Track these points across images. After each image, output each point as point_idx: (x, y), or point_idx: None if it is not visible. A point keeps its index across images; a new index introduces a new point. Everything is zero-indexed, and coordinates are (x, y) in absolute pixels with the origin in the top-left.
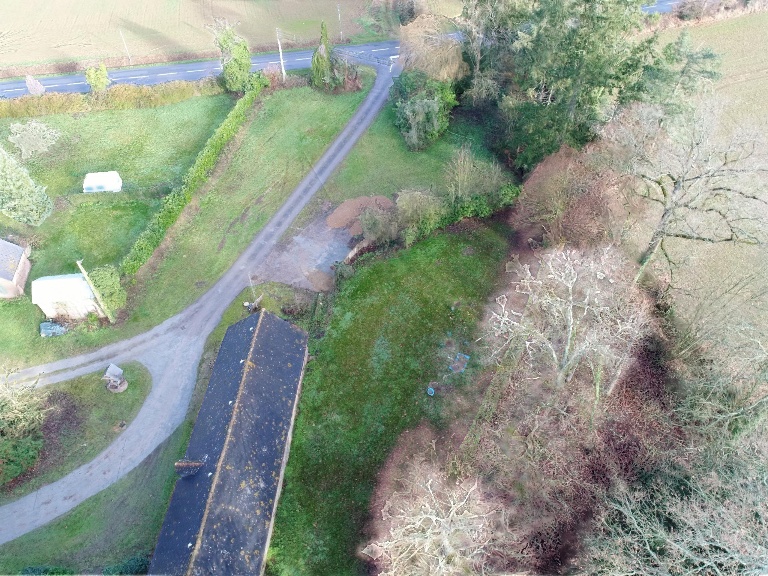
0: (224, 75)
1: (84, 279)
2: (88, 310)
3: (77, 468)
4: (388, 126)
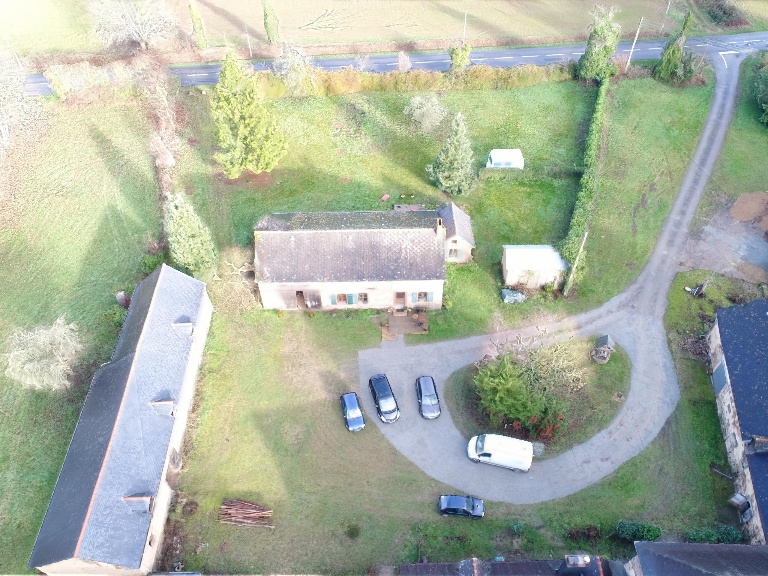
0: (585, 62)
1: (555, 251)
2: (546, 281)
3: (598, 432)
4: (752, 122)
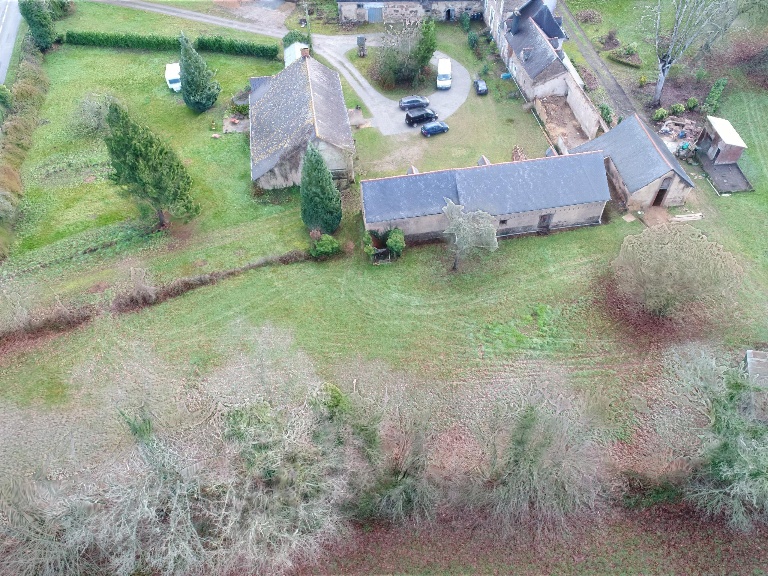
0: (44, 29)
1: (296, 42)
2: None
3: None
4: None
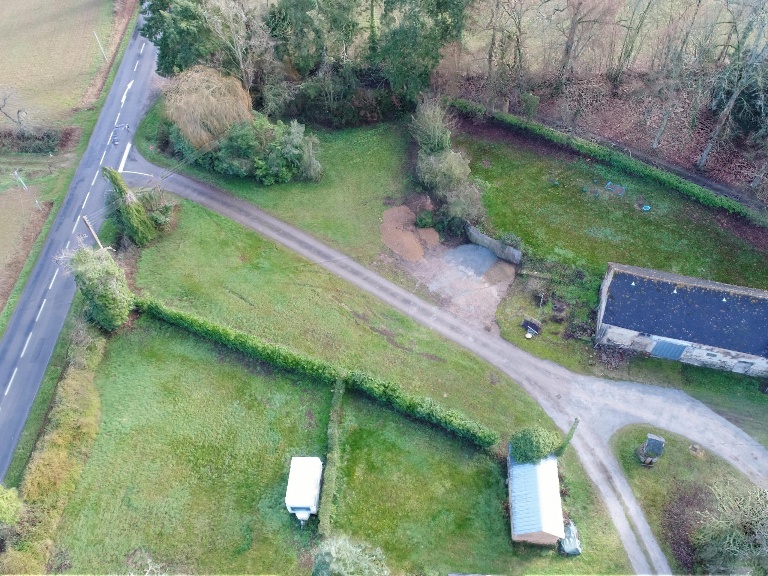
0: (111, 313)
1: (539, 463)
2: None
3: None
4: (266, 192)
